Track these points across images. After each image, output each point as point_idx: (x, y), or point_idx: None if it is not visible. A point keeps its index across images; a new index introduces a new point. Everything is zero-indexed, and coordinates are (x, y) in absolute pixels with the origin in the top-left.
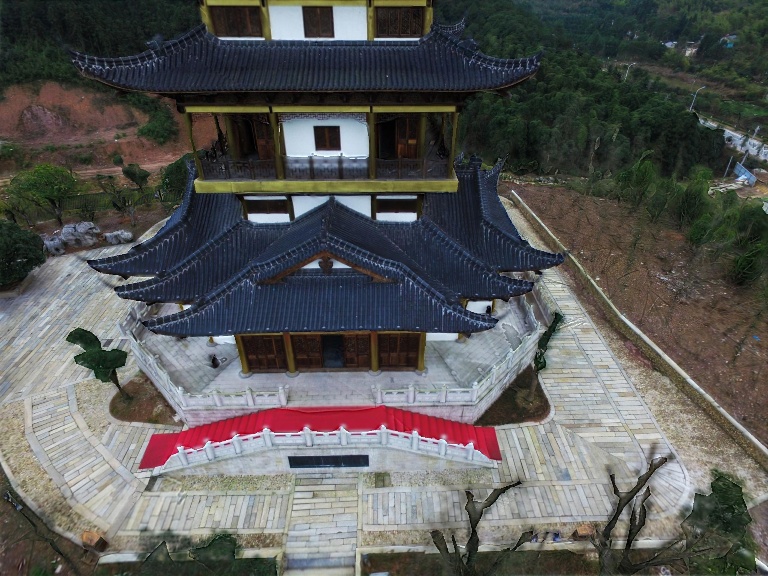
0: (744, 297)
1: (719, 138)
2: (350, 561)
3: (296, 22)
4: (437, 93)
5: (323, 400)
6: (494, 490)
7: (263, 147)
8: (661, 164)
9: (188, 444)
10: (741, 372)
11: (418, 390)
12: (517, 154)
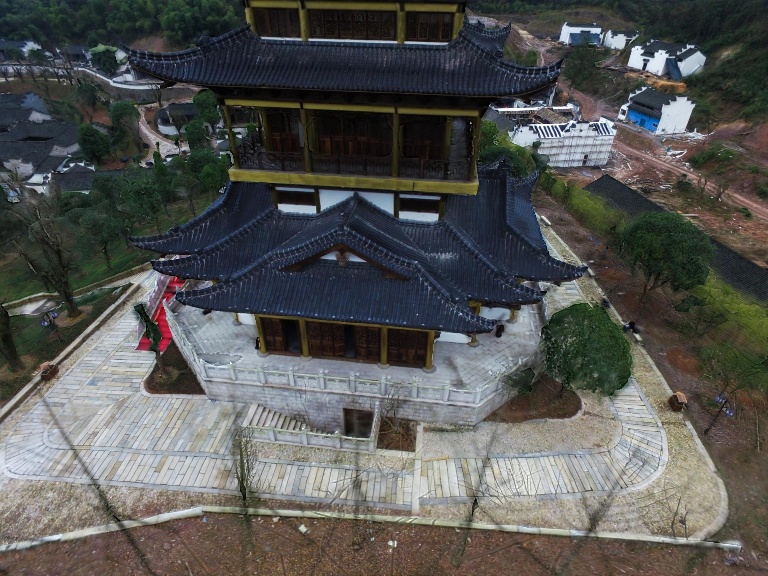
0: None
1: None
2: None
3: None
4: None
5: None
6: None
7: None
8: None
9: None
10: None
11: None
12: None
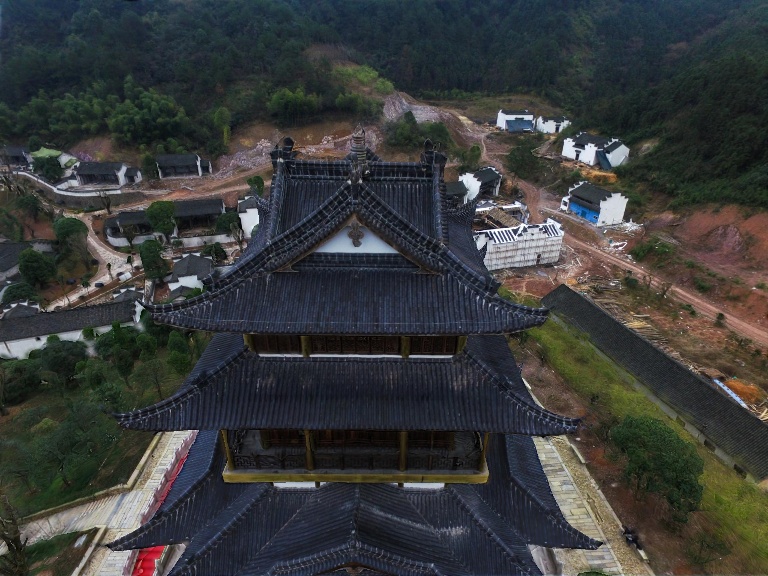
0: None
1: None
2: None
3: None
4: None
5: None
6: (0, 532)
7: None
8: None
9: None
10: None
11: None
12: None
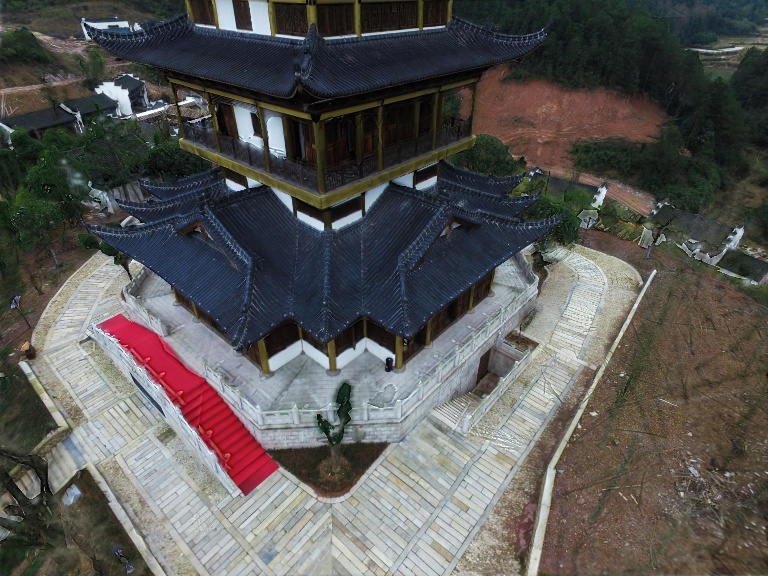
0: None
1: None
2: None
3: (231, 14)
4: (262, 94)
5: (184, 349)
6: None
7: (228, 123)
8: None
9: (118, 329)
10: None
11: (223, 382)
12: None
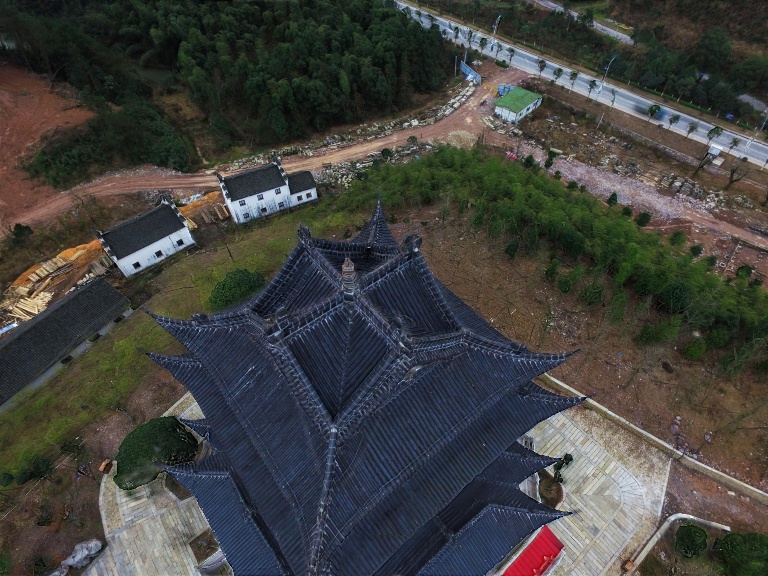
0: (596, 316)
1: (437, 34)
2: None
3: None
4: None
5: None
6: None
7: None
8: (413, 86)
9: None
10: (628, 392)
11: None
12: (290, 116)
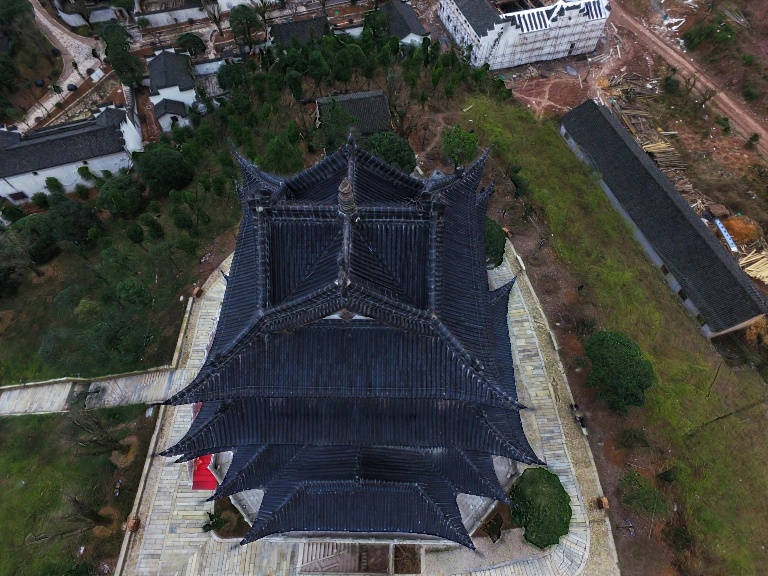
0: None
1: None
2: (164, 399)
3: None
4: None
5: None
6: None
7: None
8: None
9: None
10: None
11: None
12: None
